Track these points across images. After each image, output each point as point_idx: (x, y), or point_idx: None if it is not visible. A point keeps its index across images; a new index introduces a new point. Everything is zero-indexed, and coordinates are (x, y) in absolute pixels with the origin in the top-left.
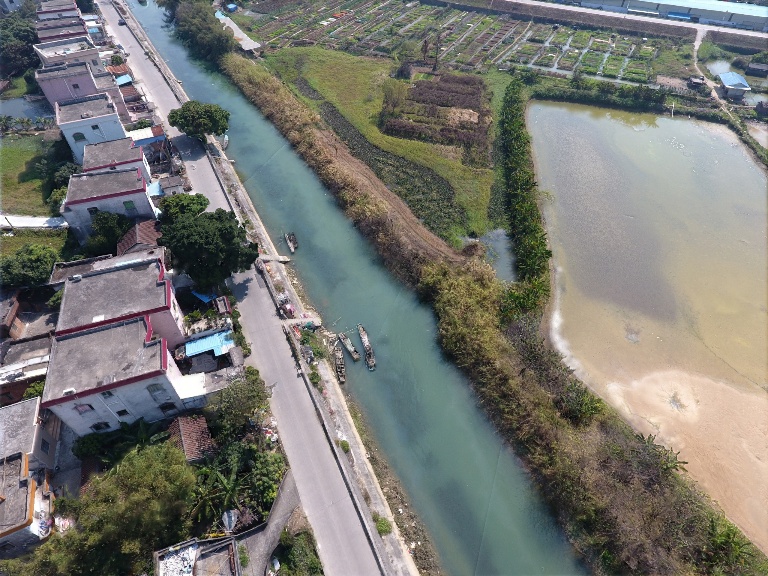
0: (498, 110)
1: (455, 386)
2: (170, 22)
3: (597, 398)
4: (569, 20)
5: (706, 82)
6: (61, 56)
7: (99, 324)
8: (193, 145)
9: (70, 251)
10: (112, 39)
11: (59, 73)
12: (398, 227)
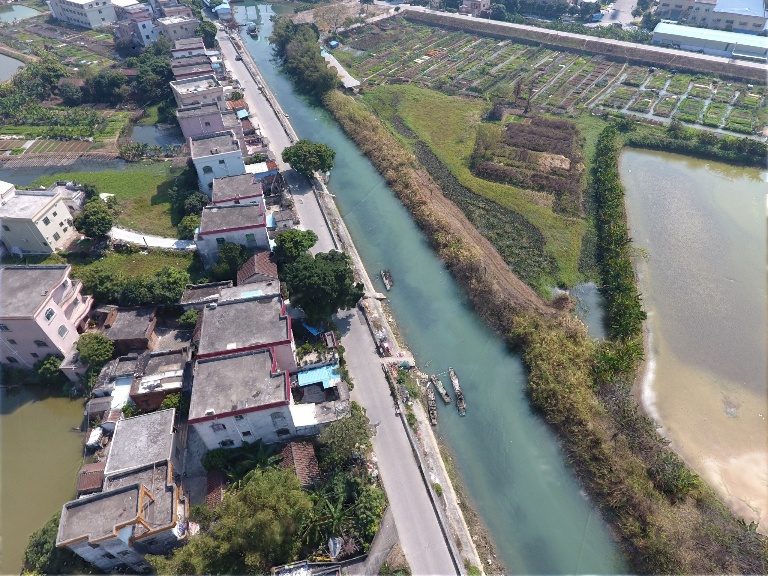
0: (590, 157)
1: (544, 442)
2: (277, 56)
3: (692, 473)
4: (667, 63)
5: None
6: (193, 93)
7: (233, 351)
8: (301, 180)
9: (196, 274)
10: (230, 74)
11: (195, 112)
12: (492, 275)
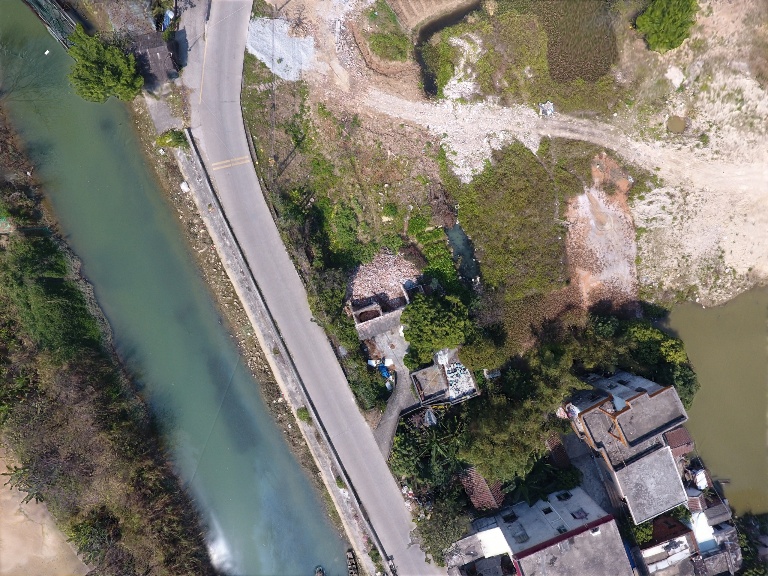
0: None
1: (229, 551)
2: None
3: None
4: None
5: None
6: None
7: None
8: None
9: None
10: None
11: None
12: None
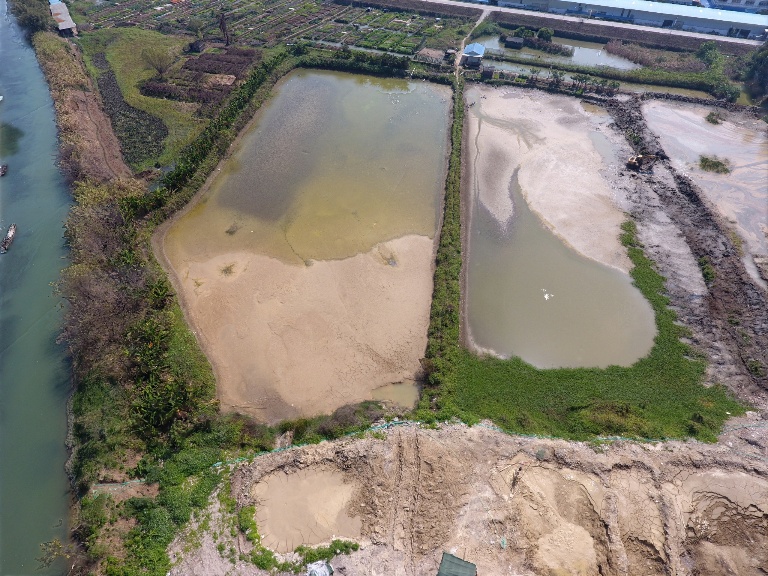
0: None
1: (61, 262)
2: None
3: None
4: (381, 4)
5: (458, 52)
6: None
7: None
8: None
9: None
10: None
11: None
12: (74, 155)
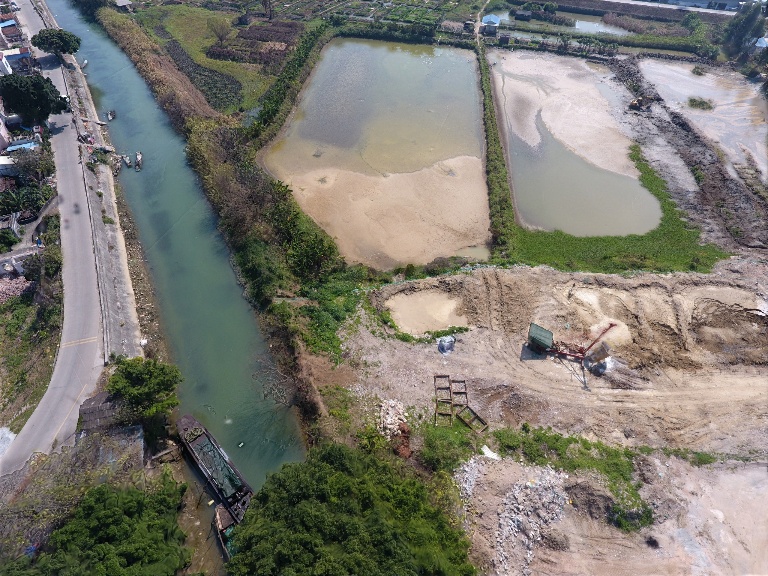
0: None
1: (188, 176)
2: None
3: None
4: None
5: (476, 23)
6: None
7: None
8: (53, 62)
9: None
10: None
11: None
12: (177, 98)
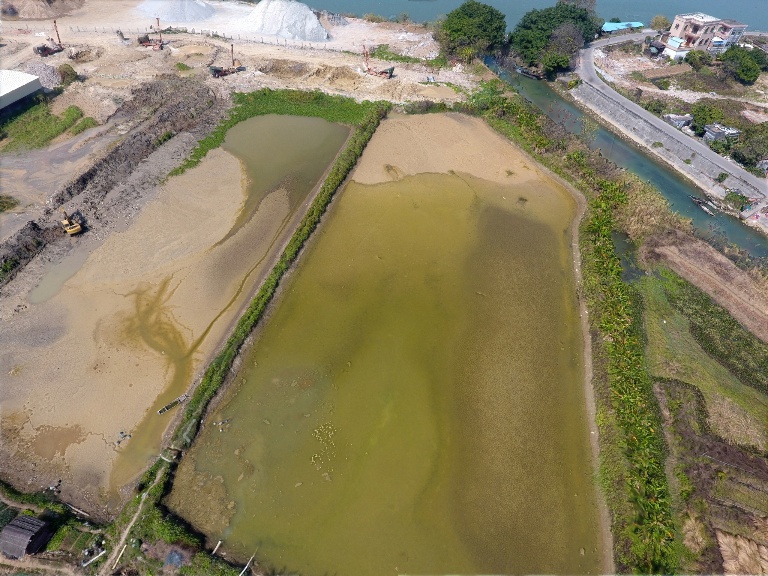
0: None
1: None
2: None
3: None
4: None
5: None
6: None
7: None
8: None
9: None
10: None
11: None
12: None
